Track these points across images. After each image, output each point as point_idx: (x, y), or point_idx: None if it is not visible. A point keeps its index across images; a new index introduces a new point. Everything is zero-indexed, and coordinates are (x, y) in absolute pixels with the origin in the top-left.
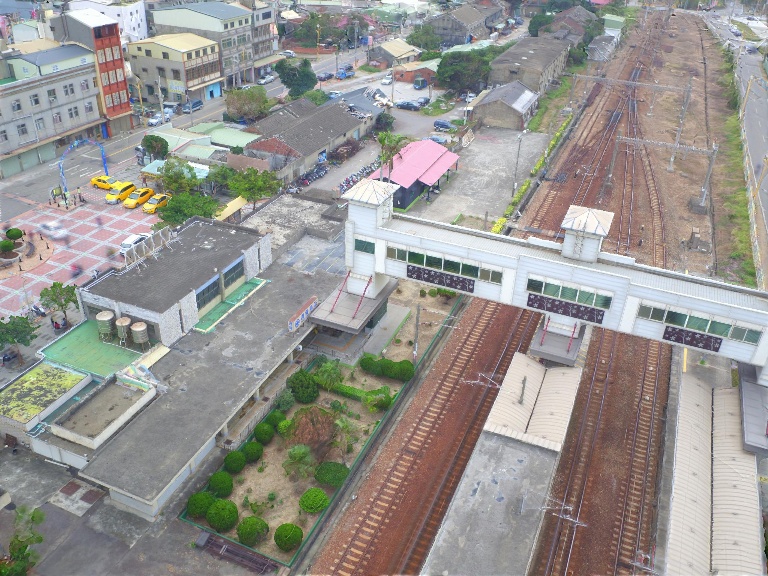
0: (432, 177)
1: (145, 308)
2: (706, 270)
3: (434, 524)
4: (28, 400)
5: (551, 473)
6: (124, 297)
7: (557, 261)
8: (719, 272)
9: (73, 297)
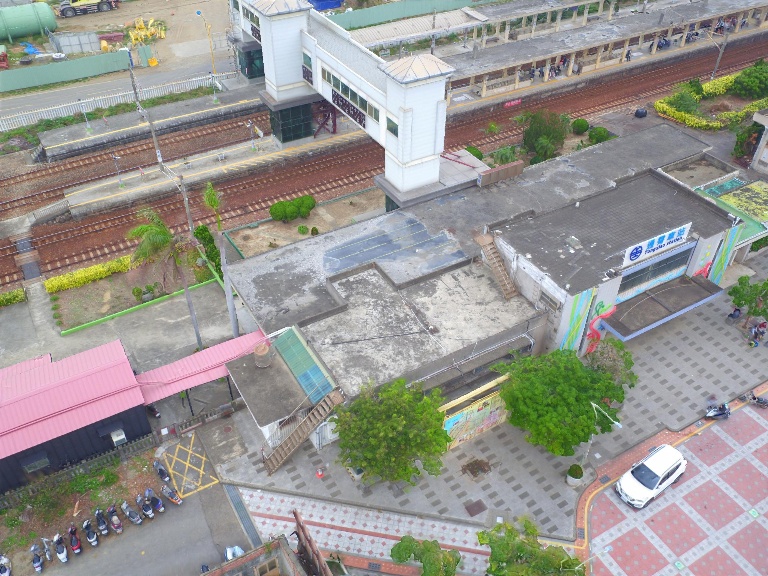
0: (6, 373)
1: (665, 186)
2: (7, 158)
3: (490, 119)
4: (765, 197)
5: (440, 58)
6: (687, 206)
7: (333, 24)
8: (3, 152)
9: (749, 285)
